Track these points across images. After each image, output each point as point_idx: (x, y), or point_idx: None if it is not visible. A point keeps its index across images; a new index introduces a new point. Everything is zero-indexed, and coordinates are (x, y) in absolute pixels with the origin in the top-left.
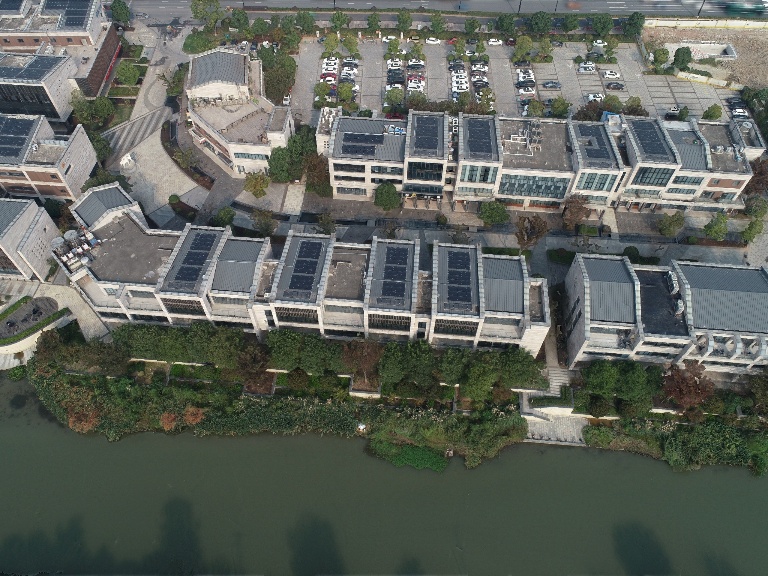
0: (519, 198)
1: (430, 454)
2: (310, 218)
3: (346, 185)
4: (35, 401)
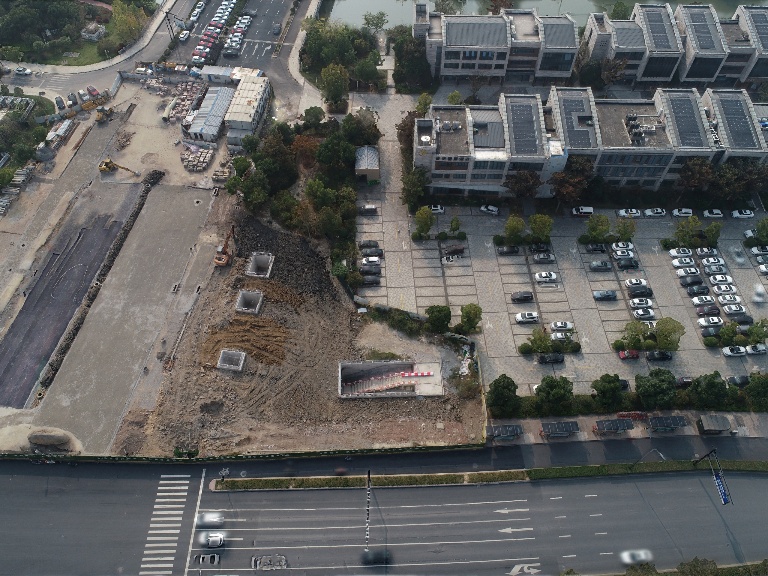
0: None
1: None
2: None
3: None
4: None
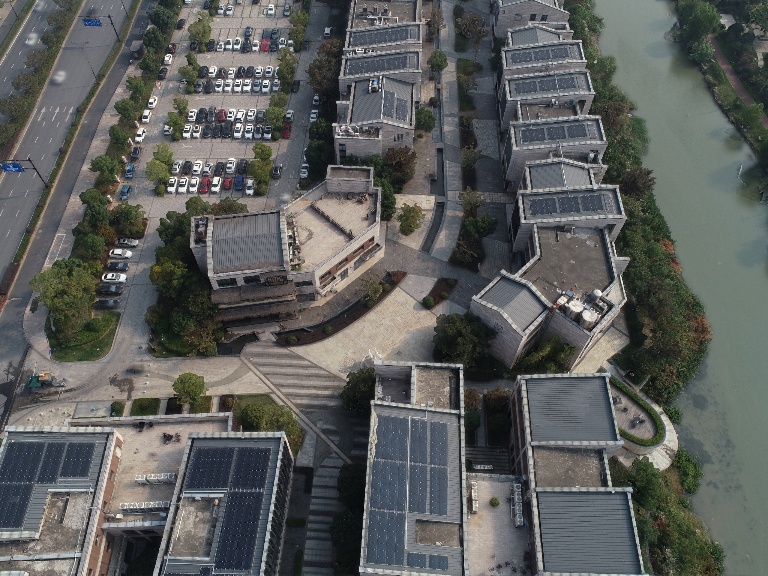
0: None
1: (635, 124)
2: (436, 190)
3: None
4: (694, 387)
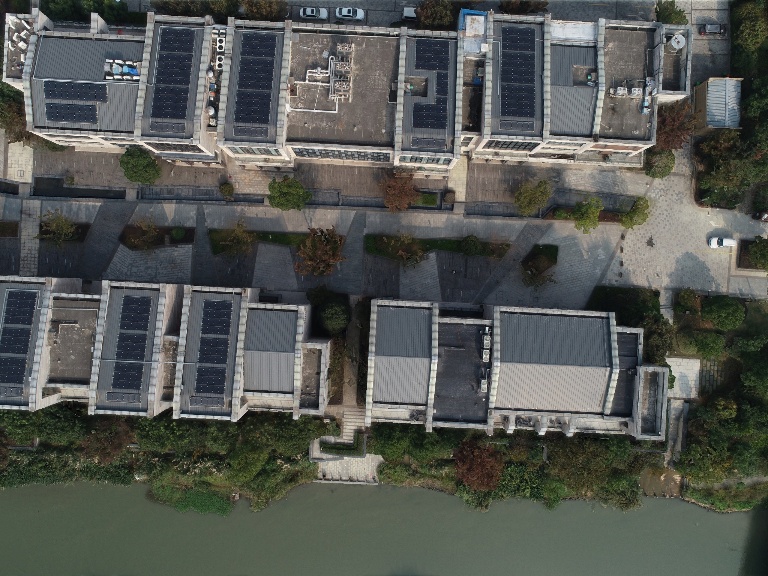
0: (329, 159)
1: (215, 499)
2: (48, 185)
3: (80, 145)
4: None
